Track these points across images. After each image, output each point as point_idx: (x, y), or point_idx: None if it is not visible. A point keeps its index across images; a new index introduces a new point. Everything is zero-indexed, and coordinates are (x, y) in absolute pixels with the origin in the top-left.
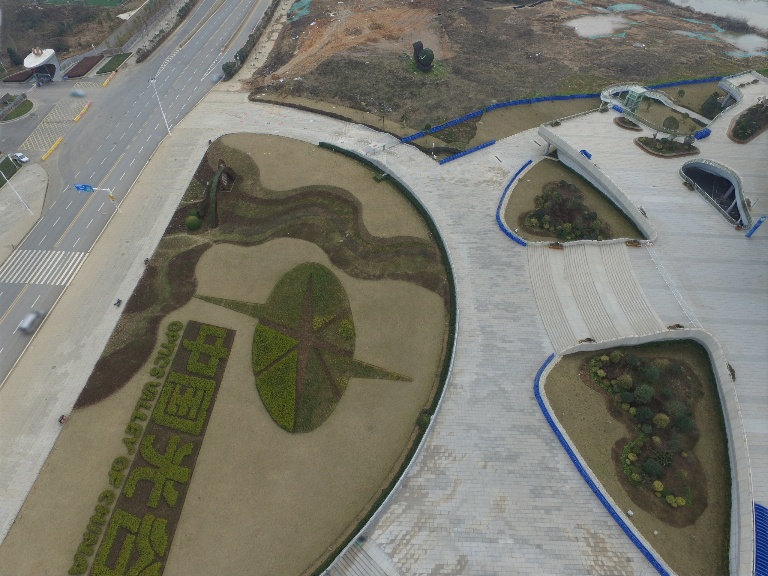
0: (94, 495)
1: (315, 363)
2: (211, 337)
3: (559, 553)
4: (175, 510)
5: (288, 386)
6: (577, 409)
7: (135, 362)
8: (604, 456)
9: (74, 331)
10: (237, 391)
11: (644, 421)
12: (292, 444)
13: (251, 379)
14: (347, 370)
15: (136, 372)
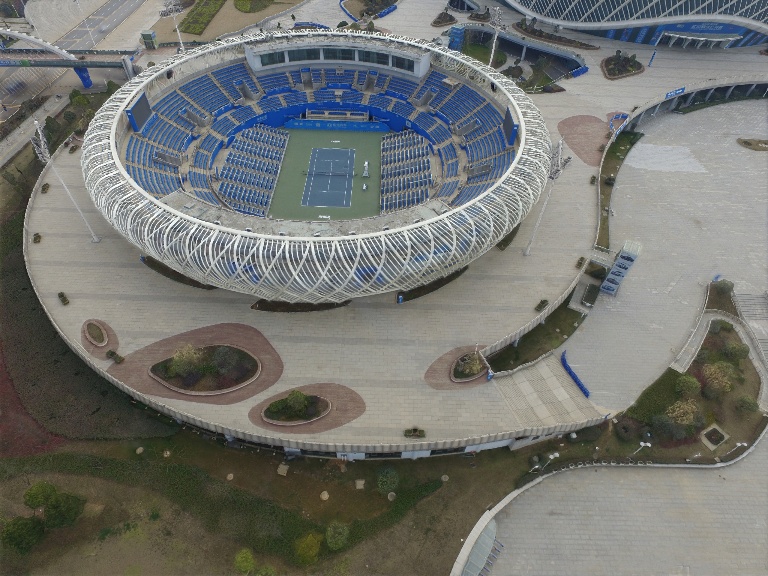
0: (178, 23)
1: (258, 2)
2: (217, 0)
3: (332, 23)
4: (207, 23)
5: (247, 5)
6: (353, 5)
7: (187, 5)
8: (357, 11)
9: (161, 1)
10: (228, 8)
11: (373, 3)
12: (248, 14)
13: (233, 6)
14: (270, 3)
15: (188, 7)
